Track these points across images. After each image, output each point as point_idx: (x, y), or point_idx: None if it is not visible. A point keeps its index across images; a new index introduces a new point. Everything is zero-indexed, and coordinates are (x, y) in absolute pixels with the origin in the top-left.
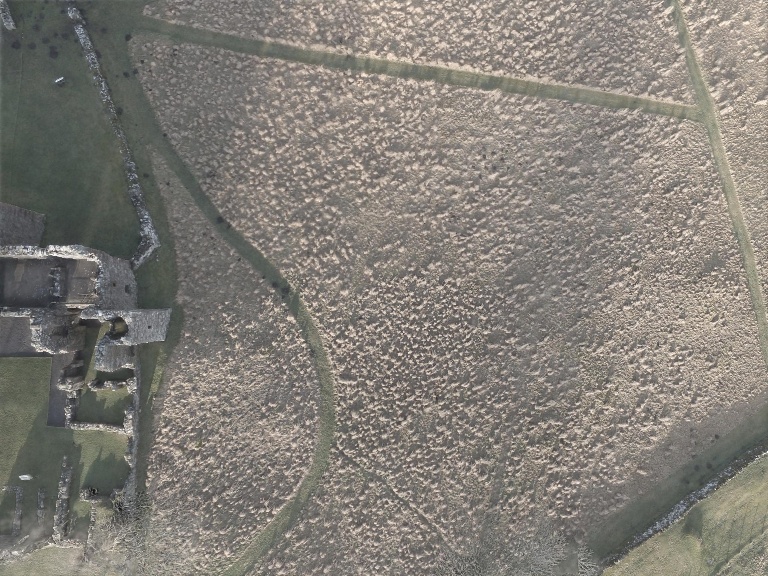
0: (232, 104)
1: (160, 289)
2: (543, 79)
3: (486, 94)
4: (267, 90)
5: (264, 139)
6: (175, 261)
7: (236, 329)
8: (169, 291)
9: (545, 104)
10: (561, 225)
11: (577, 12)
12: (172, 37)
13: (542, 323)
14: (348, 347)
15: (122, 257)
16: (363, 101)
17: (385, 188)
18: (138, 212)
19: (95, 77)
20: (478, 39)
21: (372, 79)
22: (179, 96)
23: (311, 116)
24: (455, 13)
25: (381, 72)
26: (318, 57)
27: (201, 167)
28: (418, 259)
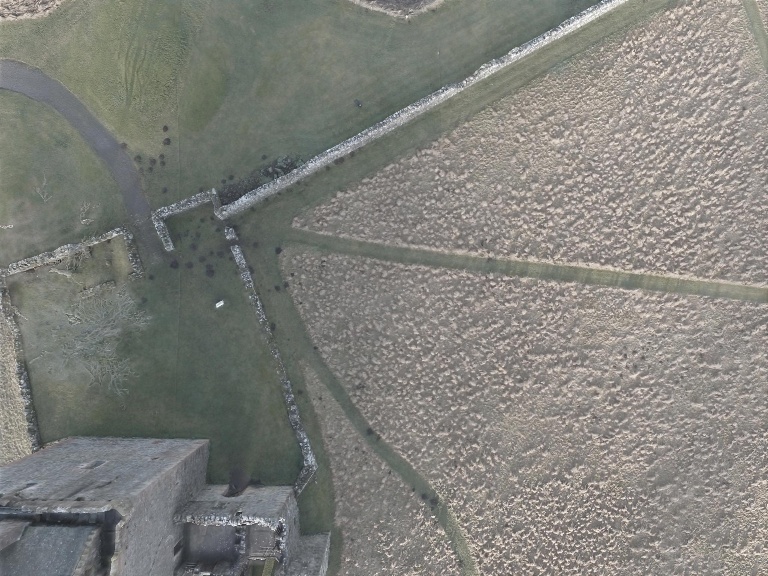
0: (379, 313)
1: (320, 512)
2: (684, 276)
3: (627, 293)
4: (412, 297)
5: (410, 348)
6: (331, 481)
7: (391, 548)
8: (328, 513)
9: (686, 301)
10: (703, 423)
11: (718, 206)
12: (320, 248)
13: (685, 524)
14: (495, 555)
15: (284, 482)
16: (505, 304)
17: (528, 391)
18: (297, 435)
19: (251, 296)
20: (618, 237)
21: (513, 282)
22: (328, 308)
23: (455, 322)
24: (595, 212)
25: (522, 274)
26: (460, 261)
27: (351, 379)
28: (561, 462)
